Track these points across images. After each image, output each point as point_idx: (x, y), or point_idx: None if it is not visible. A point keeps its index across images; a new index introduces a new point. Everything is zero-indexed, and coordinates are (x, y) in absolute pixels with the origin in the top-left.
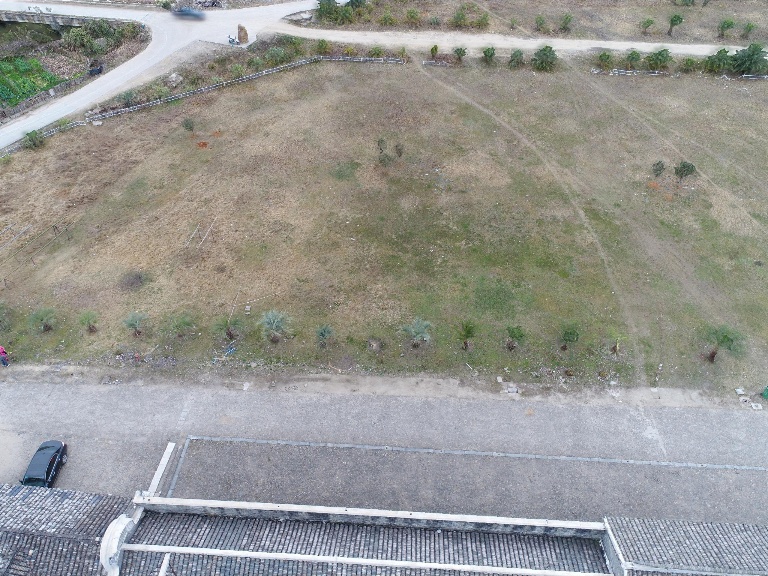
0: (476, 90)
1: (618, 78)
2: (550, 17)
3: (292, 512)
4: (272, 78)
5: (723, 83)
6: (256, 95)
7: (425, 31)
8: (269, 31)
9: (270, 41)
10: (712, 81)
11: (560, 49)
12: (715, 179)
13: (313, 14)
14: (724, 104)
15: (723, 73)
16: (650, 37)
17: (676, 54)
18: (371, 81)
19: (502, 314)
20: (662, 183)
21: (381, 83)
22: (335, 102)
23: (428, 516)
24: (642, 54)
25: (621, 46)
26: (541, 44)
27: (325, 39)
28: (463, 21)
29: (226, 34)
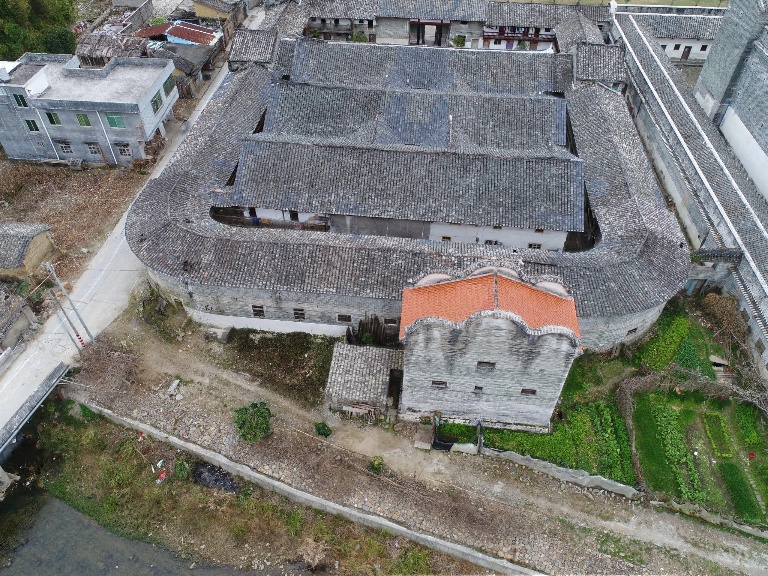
0: None
1: None
2: None
3: (670, 9)
4: None
5: None
6: None
7: None
8: None
9: None
10: None
11: None
12: None
13: None
14: None
15: None
16: None
17: None
18: None
19: (708, 1)
20: None
21: None
22: None
23: (725, 8)
24: None
25: None
26: None
27: None
28: None
29: None
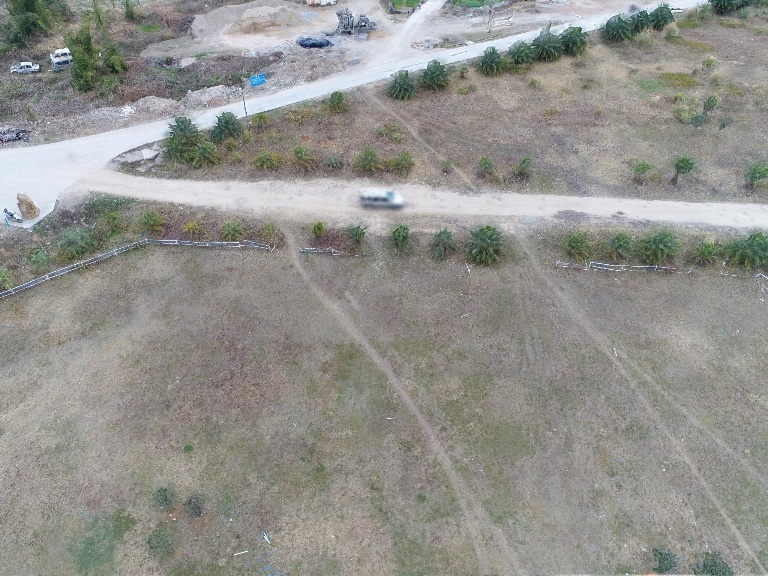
0: (373, 310)
1: (597, 278)
2: (503, 147)
3: None
4: (58, 286)
5: (759, 287)
6: (18, 328)
7: (318, 179)
8: (80, 189)
9: (76, 210)
10: (742, 283)
11: (512, 215)
12: (765, 556)
13: (162, 148)
14: (765, 340)
15: (758, 265)
16: (646, 188)
17: (685, 224)
18: (211, 291)
19: None
20: (670, 571)
21: (226, 296)
22: (139, 345)
23: None
24: (634, 225)
25: (603, 208)
26: (485, 205)
27: (165, 199)
28: (373, 165)
29: (10, 199)
